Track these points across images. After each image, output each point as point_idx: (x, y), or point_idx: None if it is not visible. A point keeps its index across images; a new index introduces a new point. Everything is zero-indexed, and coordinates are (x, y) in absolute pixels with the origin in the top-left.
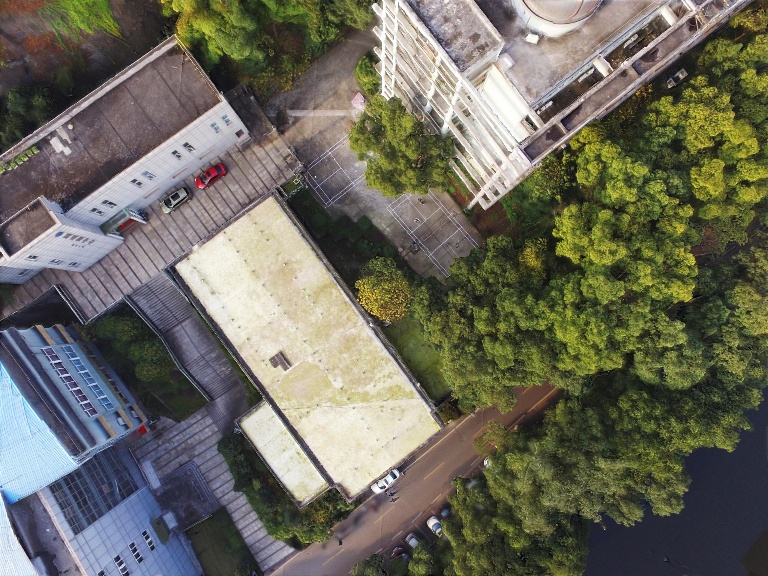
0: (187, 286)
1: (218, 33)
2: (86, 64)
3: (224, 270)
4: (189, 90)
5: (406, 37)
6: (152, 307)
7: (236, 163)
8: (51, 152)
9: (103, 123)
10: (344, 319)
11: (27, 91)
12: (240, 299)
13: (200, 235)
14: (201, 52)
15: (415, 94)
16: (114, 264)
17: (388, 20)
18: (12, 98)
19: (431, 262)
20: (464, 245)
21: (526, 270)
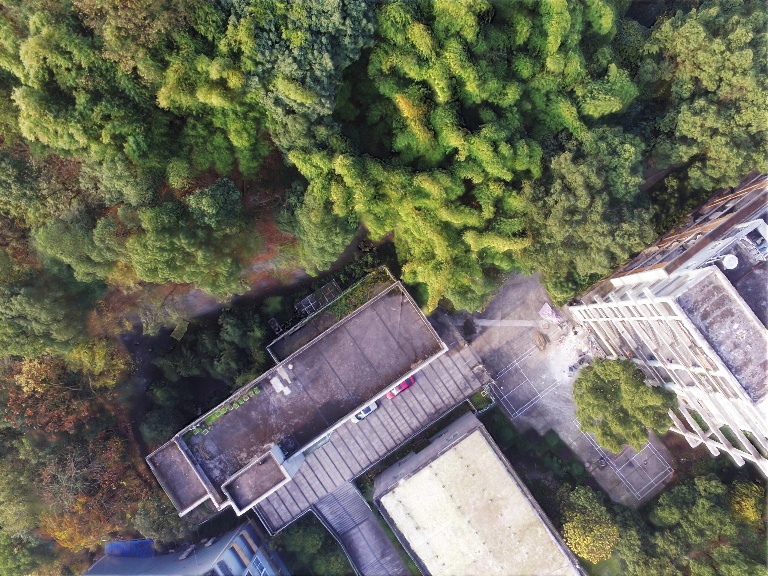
0: (391, 519)
1: (455, 296)
2: (288, 282)
3: (429, 505)
4: (407, 332)
5: (663, 327)
6: (333, 513)
7: (423, 372)
8: (271, 392)
9: (322, 364)
10: (550, 559)
11: (235, 313)
12: (445, 535)
13: (386, 444)
14: (419, 293)
15: (637, 344)
16: (300, 472)
17: (643, 307)
18: (231, 333)
19: (619, 479)
20: (652, 462)
21: (741, 518)
